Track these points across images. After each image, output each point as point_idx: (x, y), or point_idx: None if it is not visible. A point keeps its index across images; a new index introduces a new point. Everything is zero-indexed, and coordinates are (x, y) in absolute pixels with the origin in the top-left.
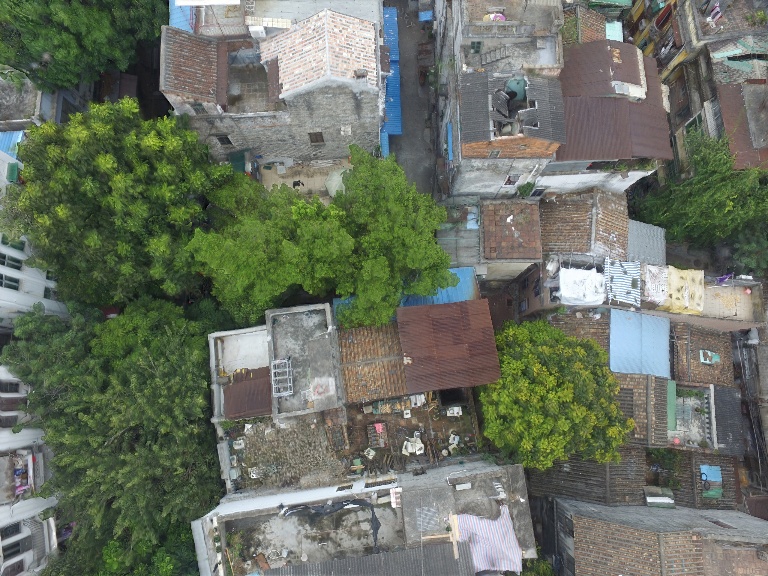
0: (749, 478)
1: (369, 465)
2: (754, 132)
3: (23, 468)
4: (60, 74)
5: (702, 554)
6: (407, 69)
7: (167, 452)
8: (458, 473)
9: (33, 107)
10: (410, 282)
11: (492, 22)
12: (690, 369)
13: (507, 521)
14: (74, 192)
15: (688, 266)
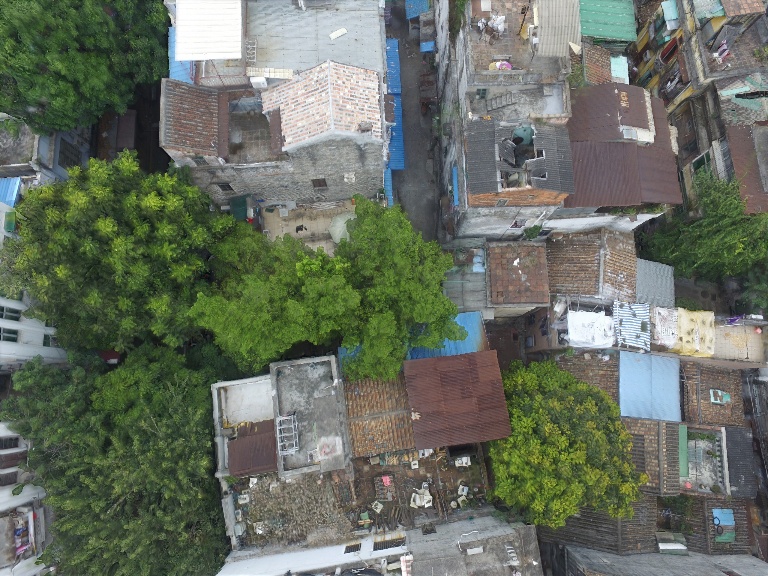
0: (761, 516)
1: (377, 520)
2: (765, 175)
3: (23, 526)
4: (58, 119)
5: None
6: (409, 99)
7: (171, 517)
8: (469, 534)
9: (30, 150)
10: (417, 332)
11: (498, 71)
12: (701, 410)
13: None
14: (73, 250)
15: (695, 297)
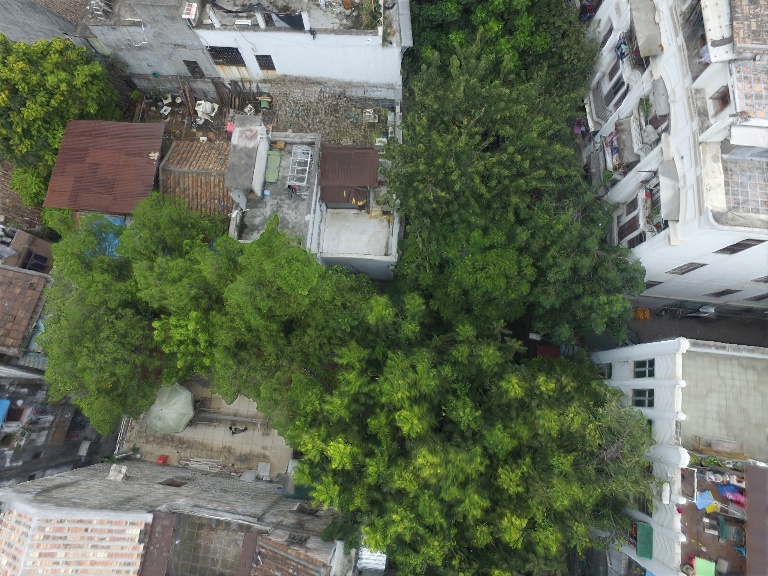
0: None
1: (251, 97)
2: None
3: None
4: None
5: None
6: None
7: None
8: (141, 42)
9: None
10: None
11: None
12: None
13: None
14: None
15: None
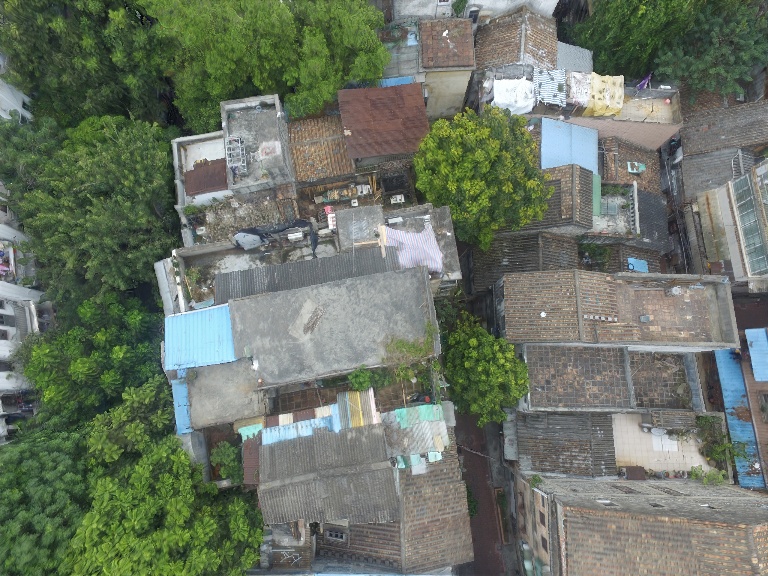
0: None
1: None
2: None
3: (5, 258)
4: None
5: (616, 295)
6: None
7: None
8: None
9: None
10: None
11: None
12: (618, 176)
13: (430, 233)
14: None
15: None
